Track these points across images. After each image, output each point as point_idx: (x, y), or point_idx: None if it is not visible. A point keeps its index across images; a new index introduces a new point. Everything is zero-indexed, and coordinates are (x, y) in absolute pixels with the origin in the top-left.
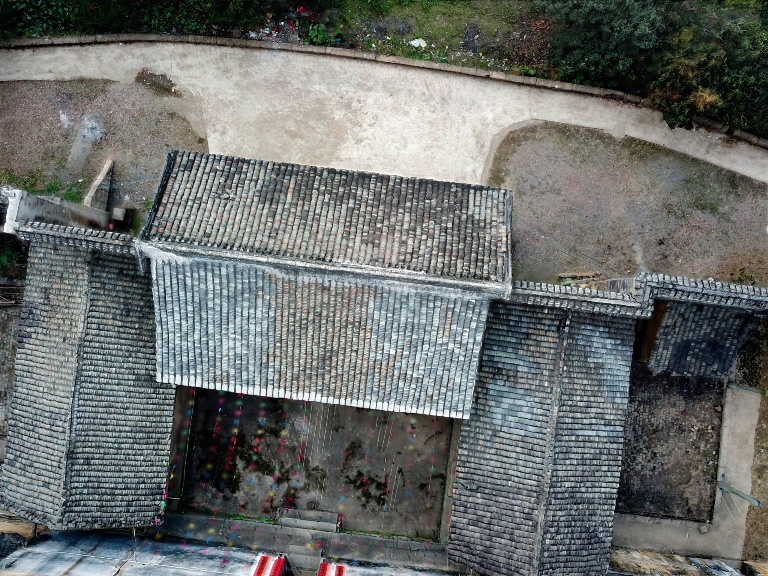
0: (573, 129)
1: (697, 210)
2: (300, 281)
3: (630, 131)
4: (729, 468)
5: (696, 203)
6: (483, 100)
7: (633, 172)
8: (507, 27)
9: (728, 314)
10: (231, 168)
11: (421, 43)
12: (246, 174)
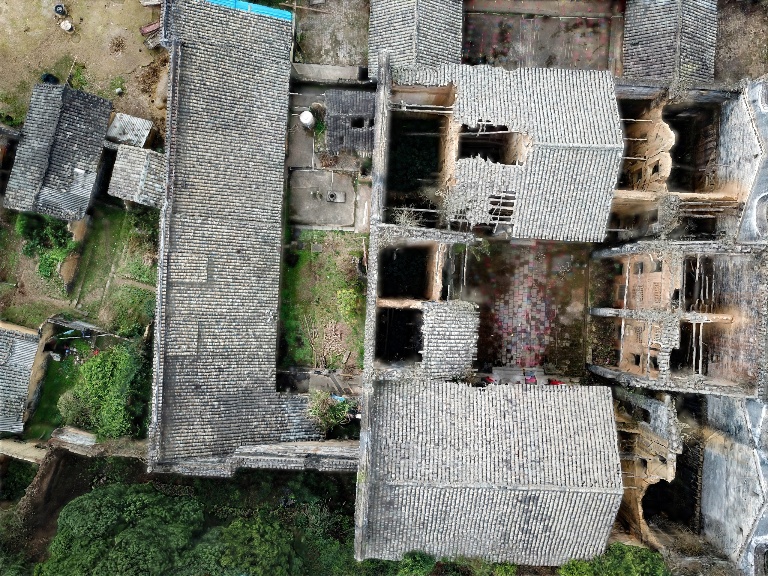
0: None
1: None
2: None
3: None
4: None
5: None
6: None
7: None
8: None
9: None
10: None
11: None
12: None
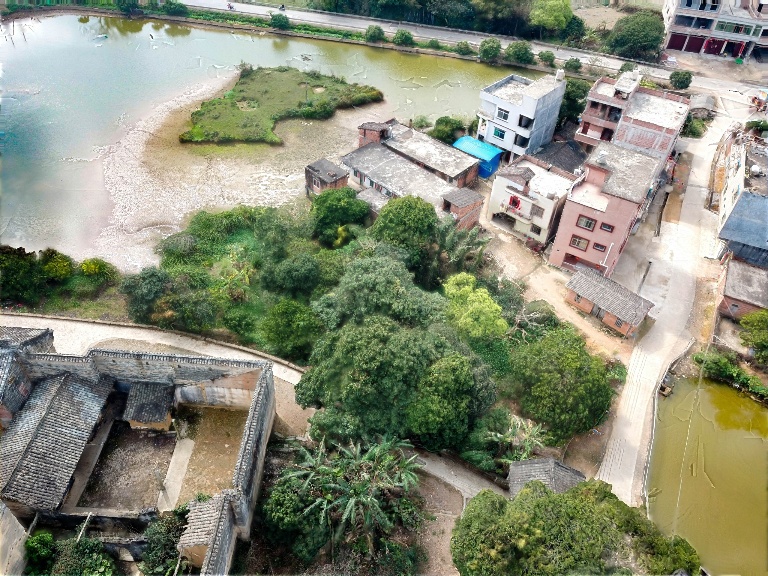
0: (131, 341)
1: None
2: None
3: (159, 341)
4: (170, 480)
5: None
6: (90, 331)
7: None
8: (123, 314)
9: (161, 388)
10: None
11: None
12: None
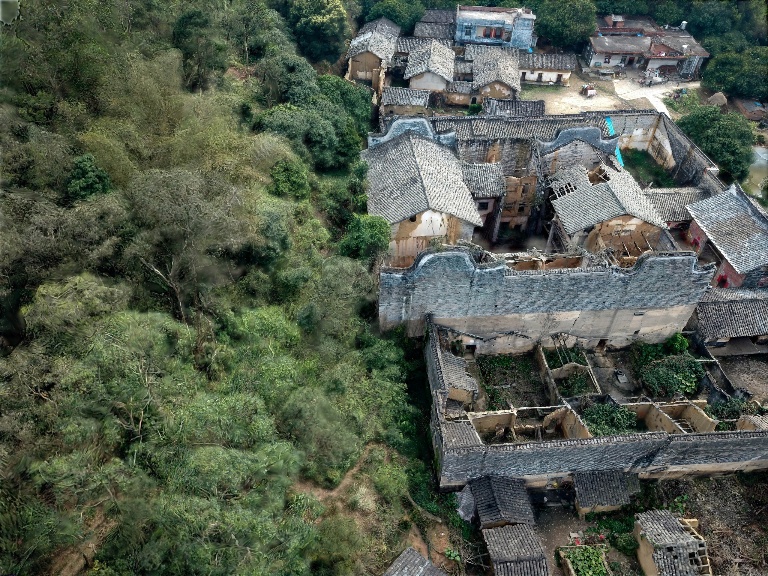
0: None
1: None
2: None
3: None
4: None
5: None
6: None
7: None
8: None
9: None
10: (762, 209)
11: None
12: (764, 212)
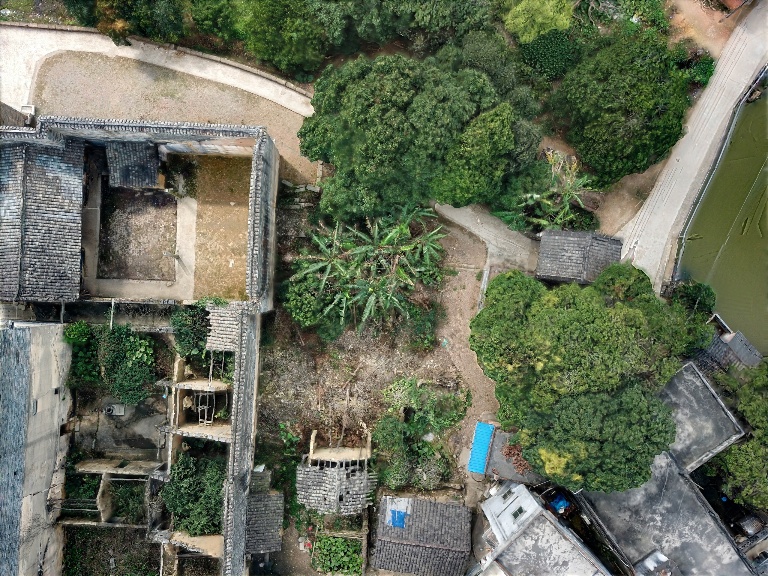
0: (84, 54)
1: (162, 97)
2: None
3: (118, 53)
4: (181, 247)
5: (161, 93)
6: (28, 41)
7: (122, 77)
8: None
9: (140, 147)
10: None
11: (7, 11)
12: None
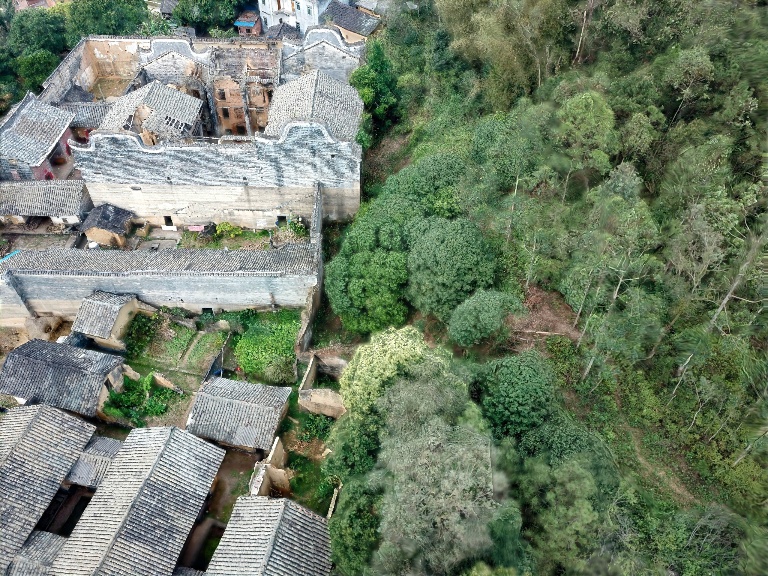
0: None
1: None
2: (14, 127)
3: None
4: None
5: None
6: None
7: None
8: None
9: (73, 91)
10: None
11: None
12: None
